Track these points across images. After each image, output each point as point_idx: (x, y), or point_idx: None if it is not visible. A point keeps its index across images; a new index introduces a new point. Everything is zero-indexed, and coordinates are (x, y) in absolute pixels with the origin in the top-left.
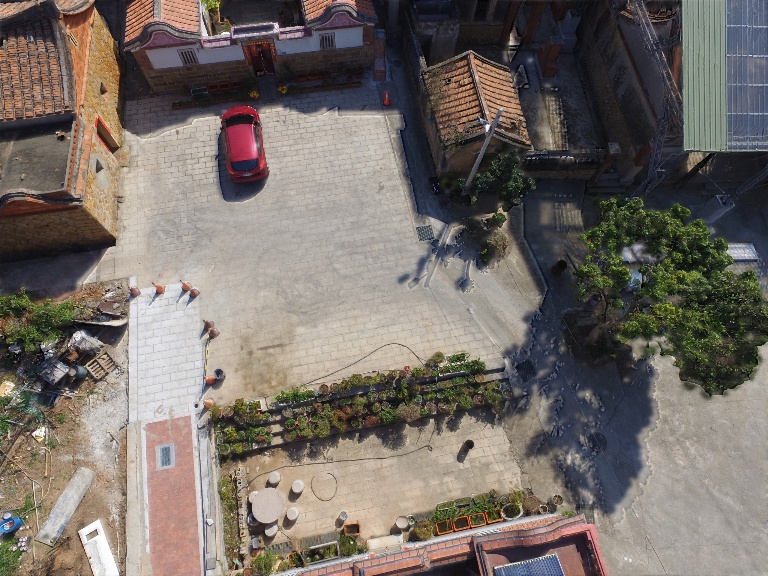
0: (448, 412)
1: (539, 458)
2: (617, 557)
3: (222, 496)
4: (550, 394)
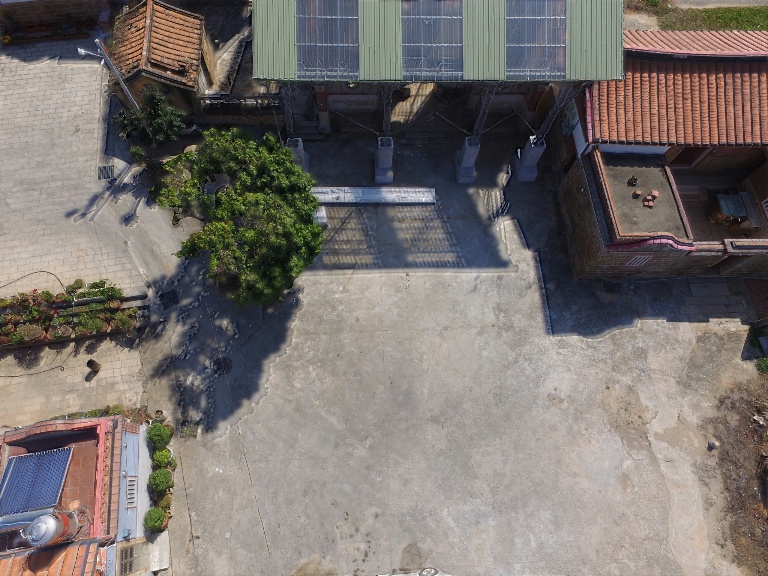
0: (90, 337)
1: (162, 379)
2: (209, 468)
3: None
4: (187, 321)
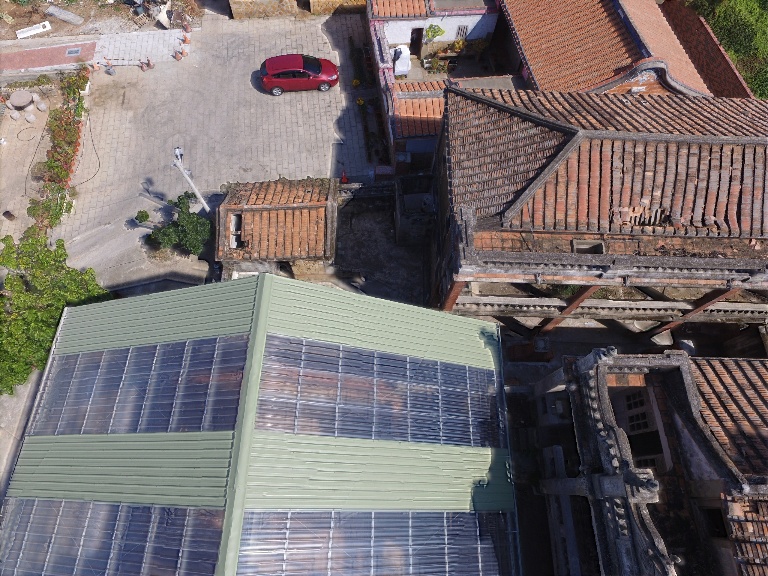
0: None
1: None
2: None
3: (39, 78)
4: None
